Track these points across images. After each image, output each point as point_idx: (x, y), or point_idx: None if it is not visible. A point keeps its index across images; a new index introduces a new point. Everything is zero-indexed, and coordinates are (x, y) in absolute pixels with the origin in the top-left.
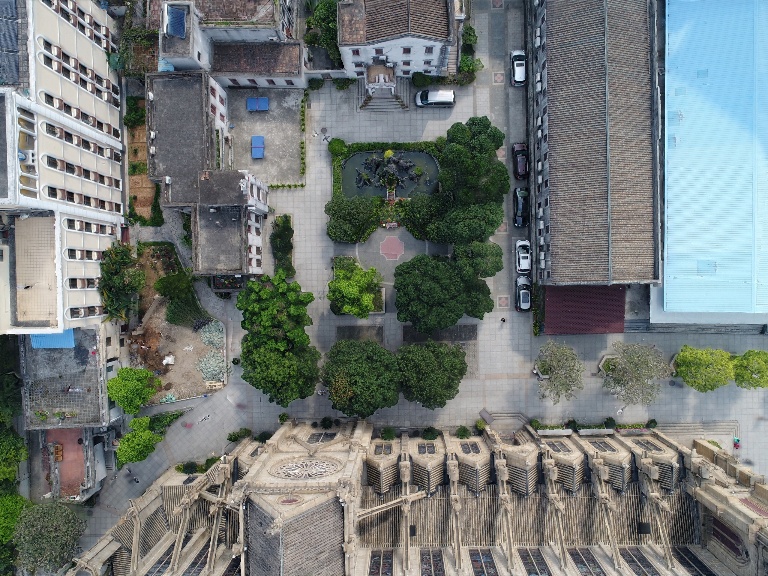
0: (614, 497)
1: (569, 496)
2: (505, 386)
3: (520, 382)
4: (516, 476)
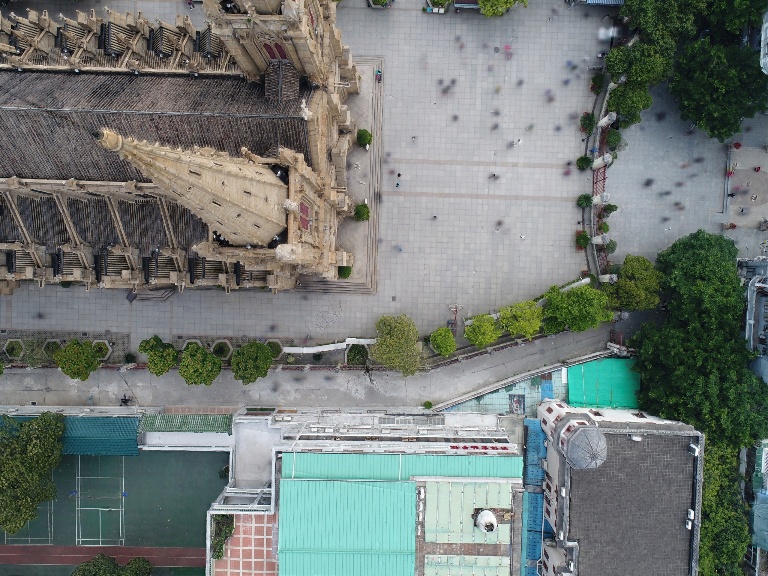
0: (204, 64)
1: (160, 61)
2: (156, 9)
3: (171, 5)
4: (107, 36)
